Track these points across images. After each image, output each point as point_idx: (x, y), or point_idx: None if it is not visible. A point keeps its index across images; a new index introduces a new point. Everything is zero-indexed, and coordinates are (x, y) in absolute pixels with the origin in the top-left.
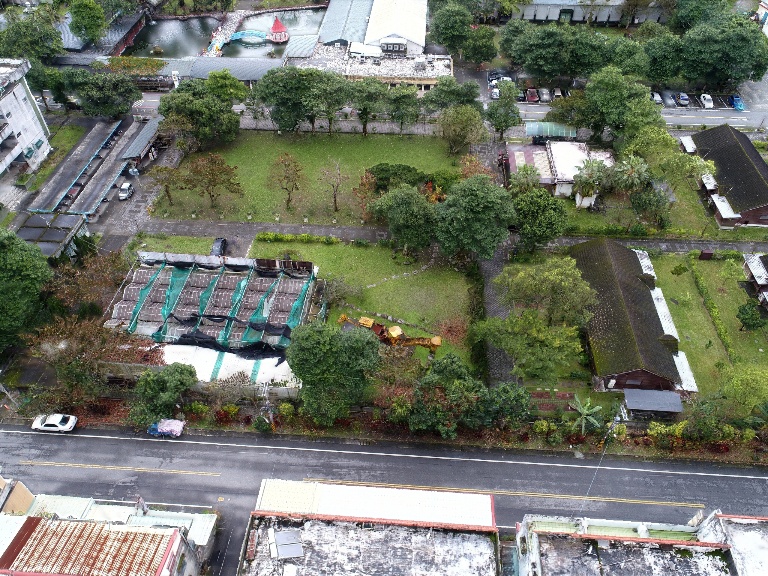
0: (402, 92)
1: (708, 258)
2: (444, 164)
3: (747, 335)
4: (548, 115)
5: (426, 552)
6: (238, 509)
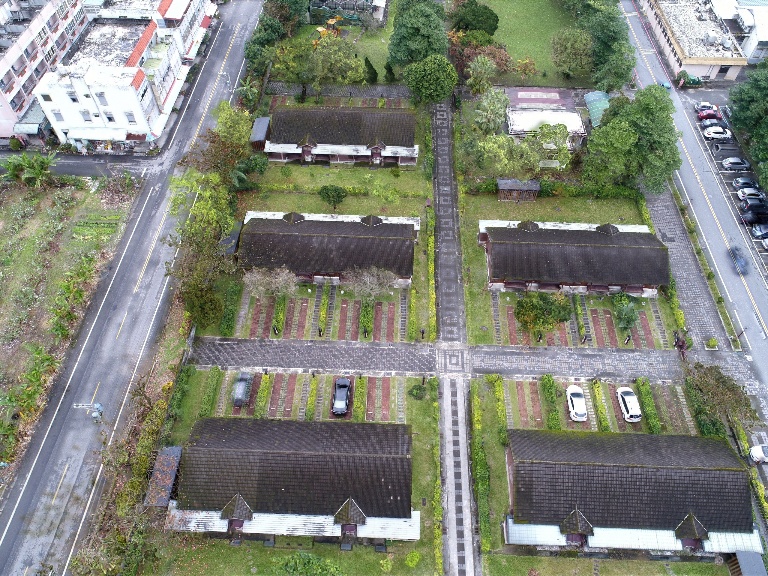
0: None
1: None
2: None
3: (329, 210)
4: None
5: (158, 0)
6: (228, 8)
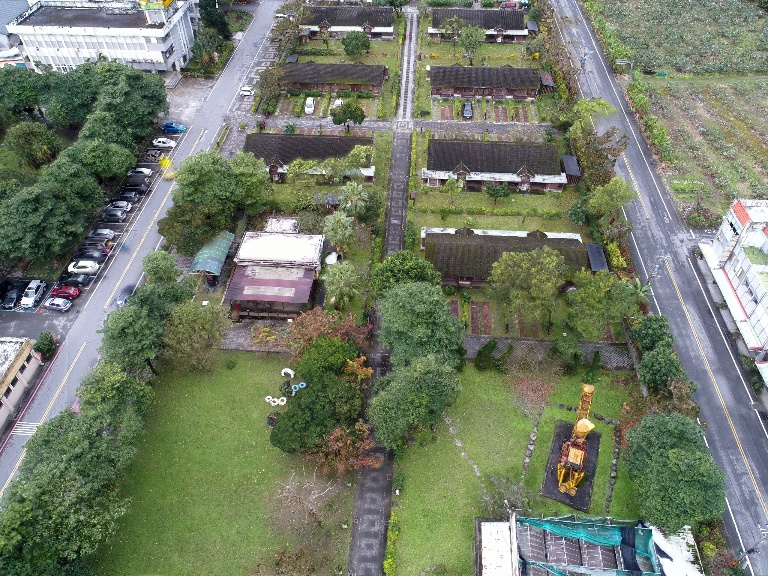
0: (111, 384)
1: (414, 200)
2: (227, 377)
3: (500, 202)
4: (186, 248)
5: None
6: None
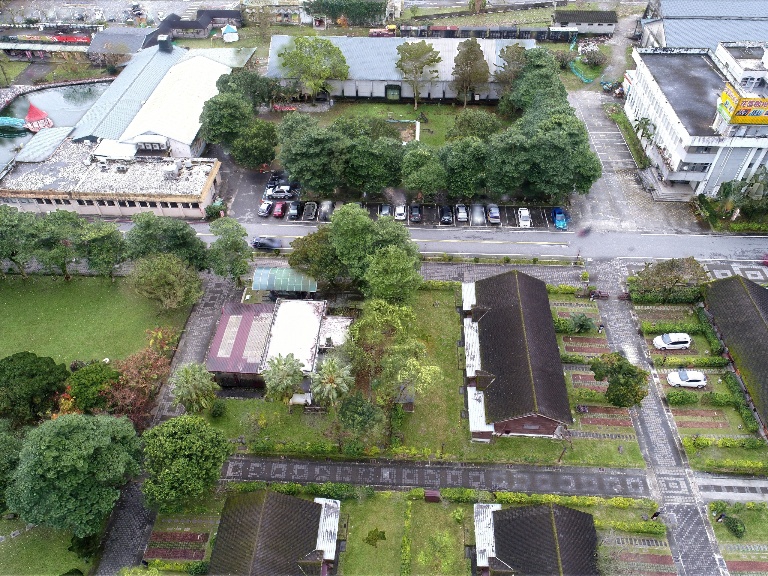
0: None
1: (436, 500)
2: (146, 328)
3: None
4: (291, 257)
5: None
6: None
